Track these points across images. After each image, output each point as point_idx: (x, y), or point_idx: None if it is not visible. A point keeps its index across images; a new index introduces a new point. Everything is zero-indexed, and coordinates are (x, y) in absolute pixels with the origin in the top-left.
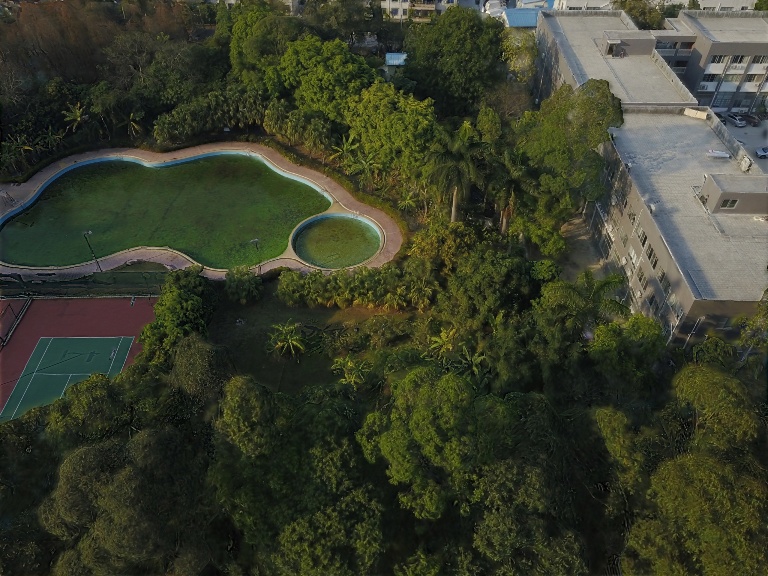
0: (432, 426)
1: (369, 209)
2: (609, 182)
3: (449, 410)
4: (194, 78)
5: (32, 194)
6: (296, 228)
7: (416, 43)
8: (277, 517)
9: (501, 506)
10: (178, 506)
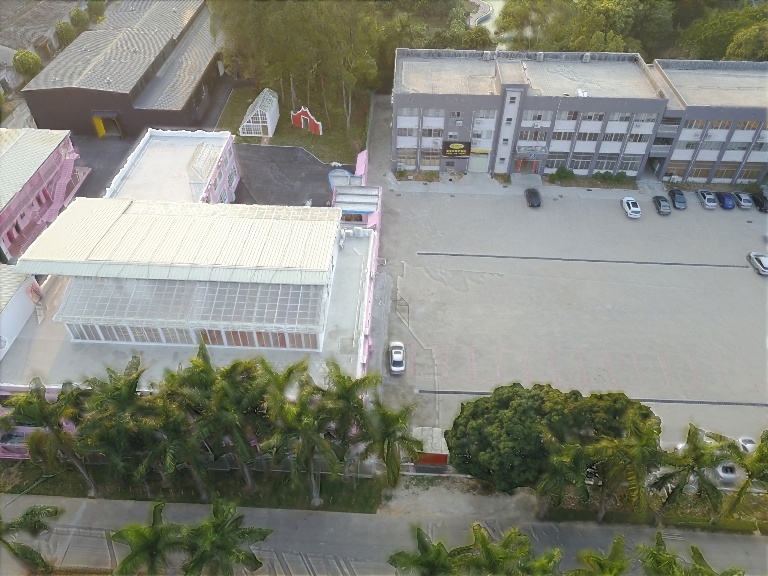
0: None
1: None
2: None
3: None
4: None
5: None
6: None
7: None
8: None
9: None
10: None
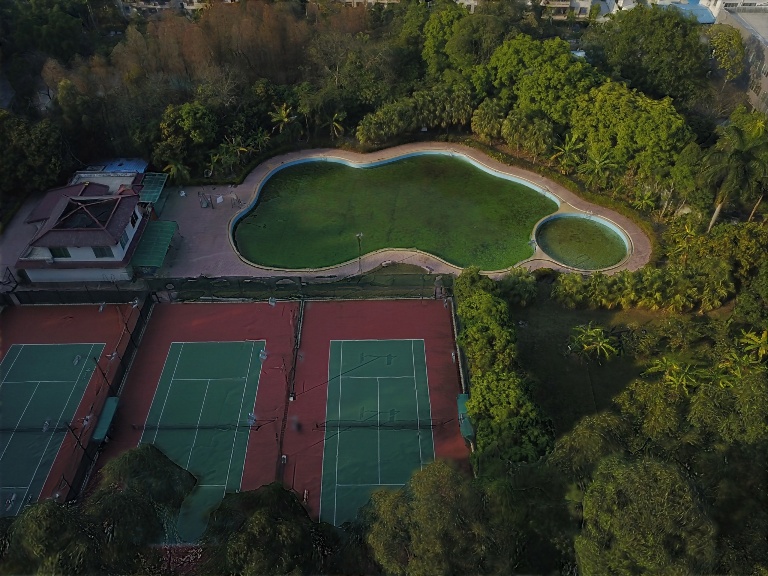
0: None
1: (600, 209)
2: None
3: None
4: (391, 78)
5: (253, 195)
6: (535, 229)
7: (597, 41)
8: None
9: None
10: None
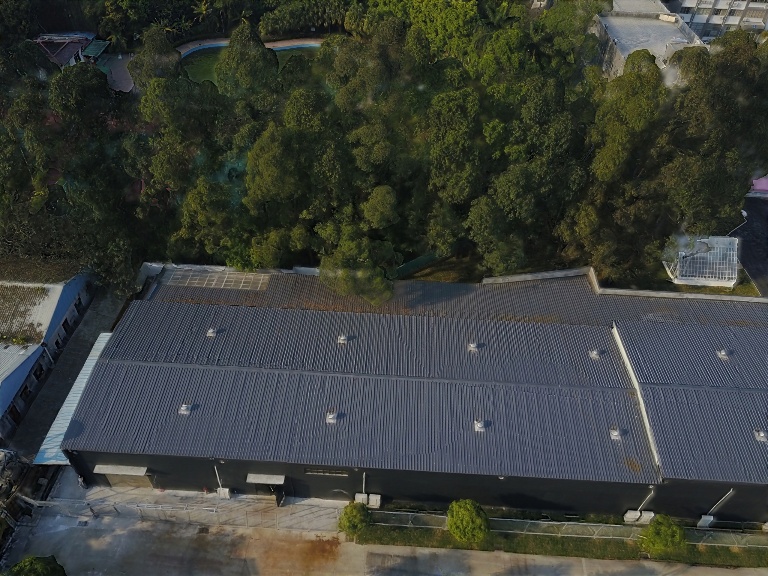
0: (507, 45)
1: None
2: (602, 58)
3: (515, 38)
4: None
5: None
6: None
7: None
8: (430, 95)
9: (535, 93)
10: (391, 73)
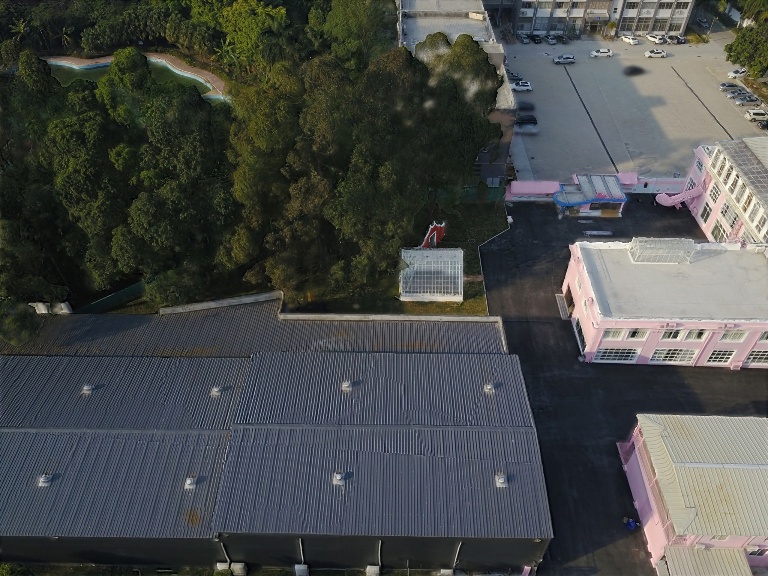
0: (116, 66)
1: None
2: None
3: (124, 58)
4: (115, 2)
5: None
6: None
7: None
8: (48, 122)
9: None
10: None
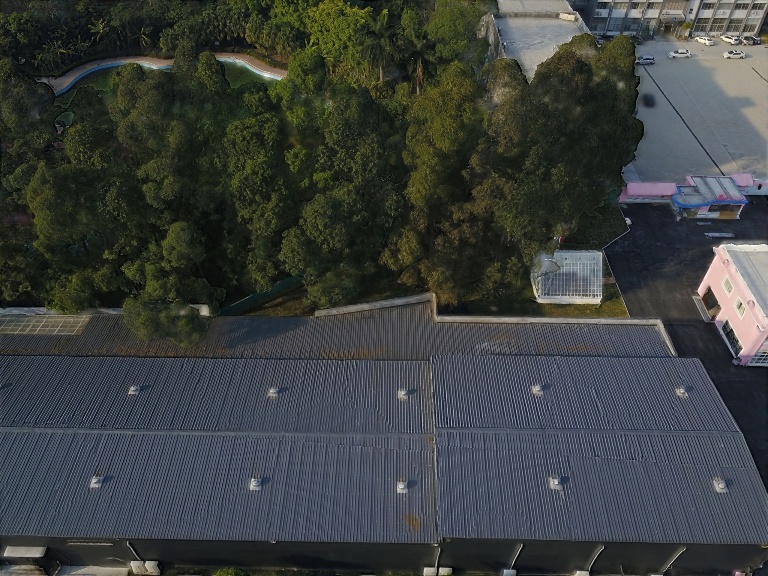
0: (299, 67)
1: None
2: None
3: (307, 59)
4: (192, 2)
5: (66, 84)
6: None
7: None
8: (225, 123)
9: (337, 116)
10: (175, 103)
